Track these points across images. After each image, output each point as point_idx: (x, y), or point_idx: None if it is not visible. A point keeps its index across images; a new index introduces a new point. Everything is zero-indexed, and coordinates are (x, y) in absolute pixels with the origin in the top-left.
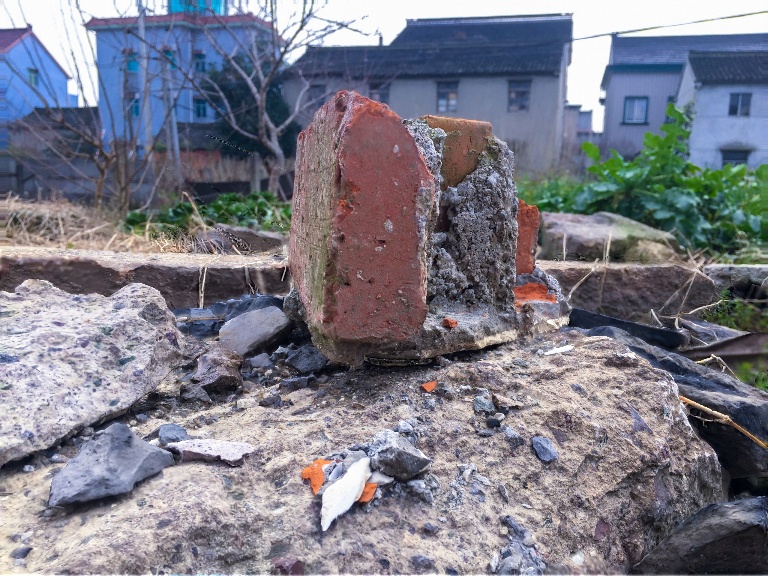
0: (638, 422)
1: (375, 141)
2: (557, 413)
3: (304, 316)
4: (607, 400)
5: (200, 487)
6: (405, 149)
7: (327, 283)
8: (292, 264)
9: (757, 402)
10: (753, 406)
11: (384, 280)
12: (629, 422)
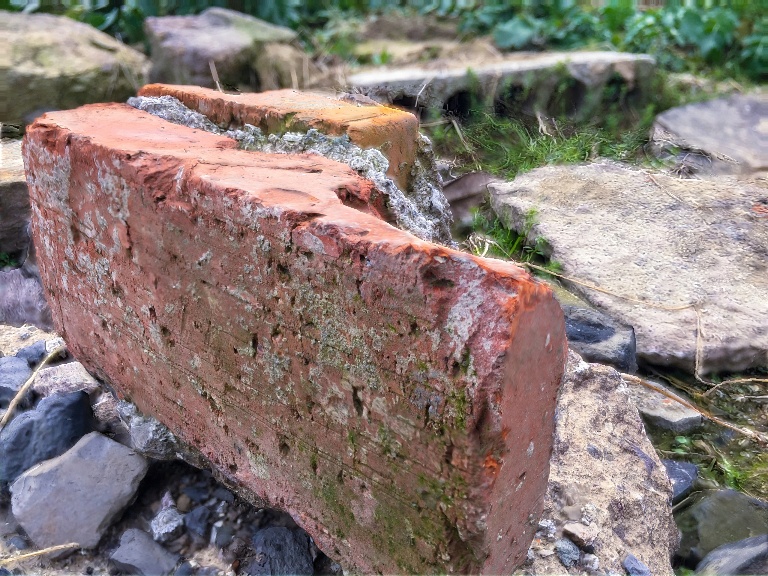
0: (646, 461)
1: (530, 347)
2: (611, 507)
3: (192, 461)
4: (611, 446)
5: None
6: (556, 334)
7: (456, 570)
8: (98, 357)
9: (625, 336)
10: (629, 345)
11: (519, 517)
12: (642, 466)
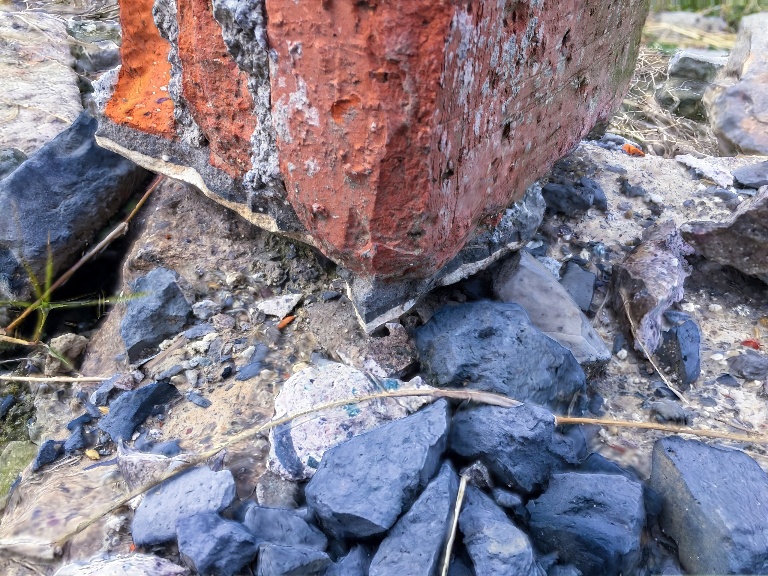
0: None
1: None
2: None
3: None
4: None
5: (713, 160)
6: None
7: None
8: (491, 196)
9: None
10: None
11: None
12: None
